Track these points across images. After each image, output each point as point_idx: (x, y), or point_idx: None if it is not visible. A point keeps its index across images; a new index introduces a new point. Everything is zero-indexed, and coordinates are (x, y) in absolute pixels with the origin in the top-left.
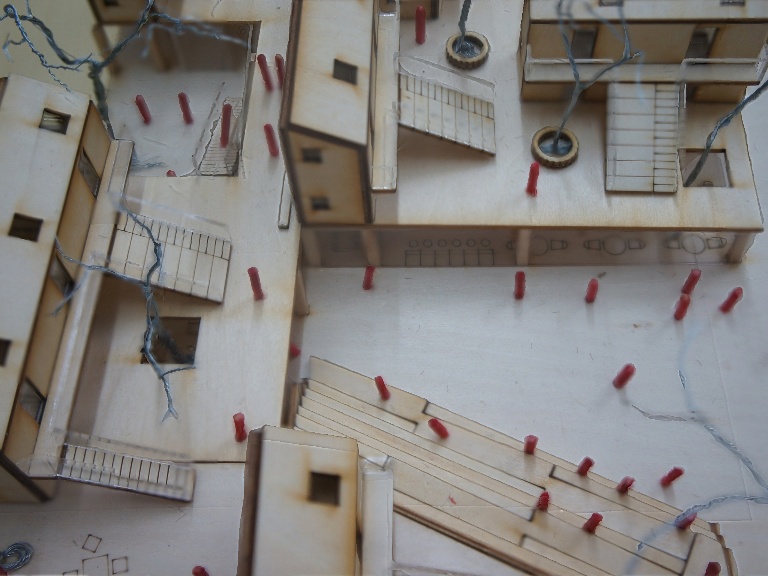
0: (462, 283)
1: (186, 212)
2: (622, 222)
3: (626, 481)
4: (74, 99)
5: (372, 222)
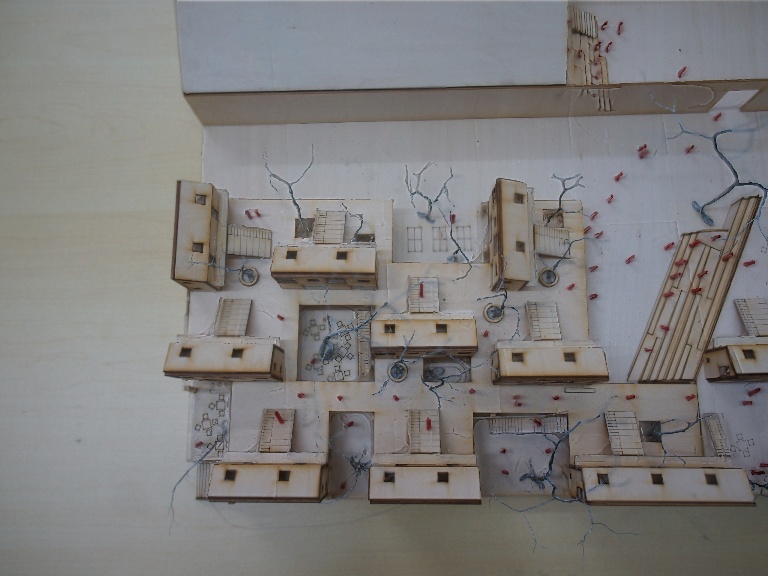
0: None
1: (589, 434)
2: (583, 254)
3: None
4: (588, 474)
5: None
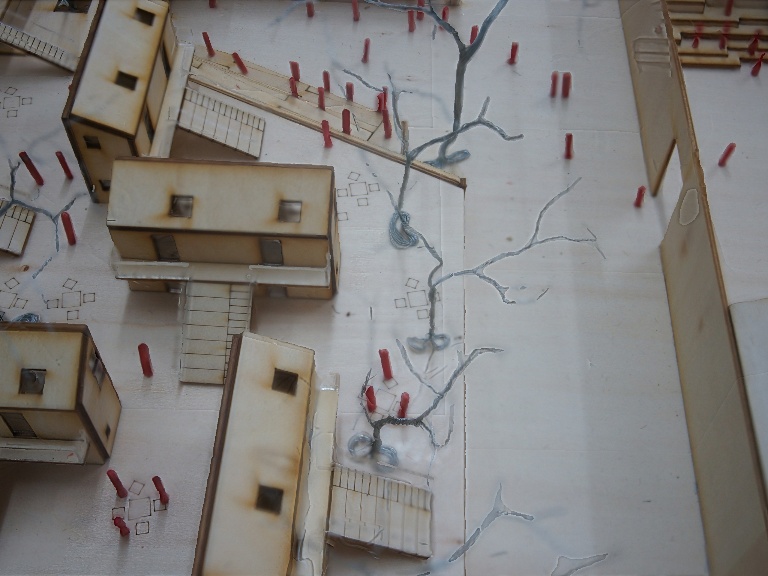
0: (275, 8)
1: None
2: None
3: (347, 84)
4: None
5: None
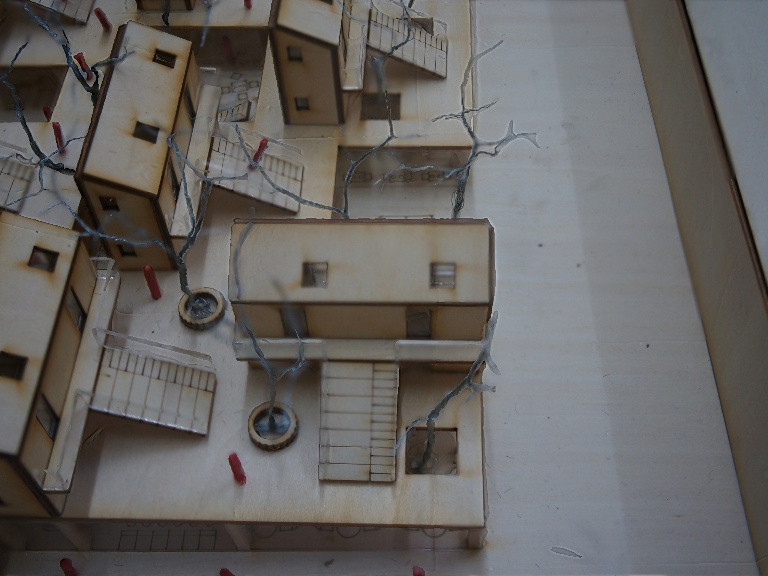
0: (176, 571)
1: None
2: (332, 517)
3: None
4: None
5: (60, 515)
